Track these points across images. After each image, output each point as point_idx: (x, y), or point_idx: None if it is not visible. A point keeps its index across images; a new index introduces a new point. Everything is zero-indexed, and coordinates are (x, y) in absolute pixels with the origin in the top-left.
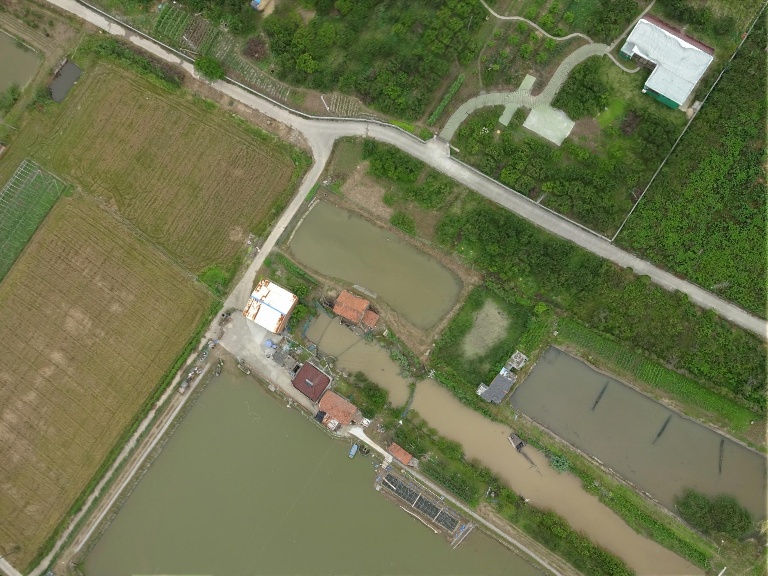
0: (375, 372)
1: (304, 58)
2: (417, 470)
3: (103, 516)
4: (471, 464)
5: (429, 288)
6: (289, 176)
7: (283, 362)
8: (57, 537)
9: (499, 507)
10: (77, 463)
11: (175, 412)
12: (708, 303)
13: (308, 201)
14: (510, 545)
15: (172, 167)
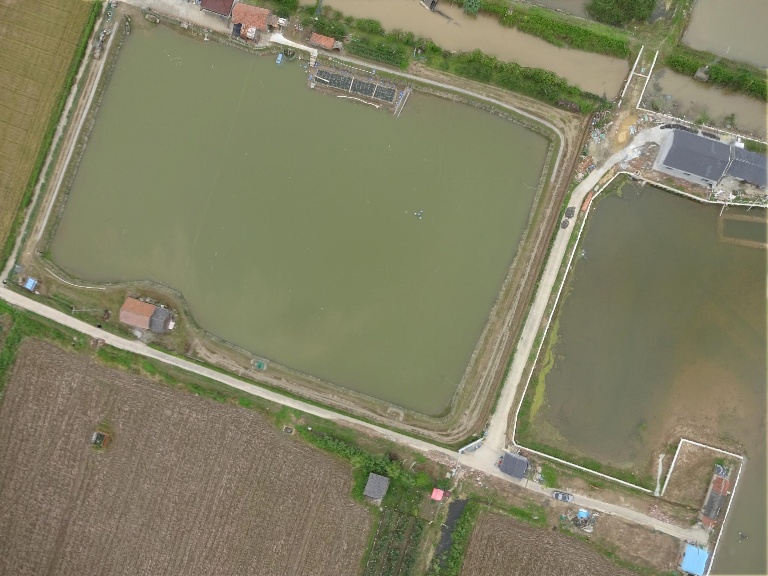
0: None
1: None
2: (343, 54)
3: (55, 198)
4: (392, 34)
5: None
6: None
7: None
8: (15, 234)
9: (428, 60)
10: (14, 159)
11: (97, 79)
12: None
13: None
14: (448, 93)
15: None
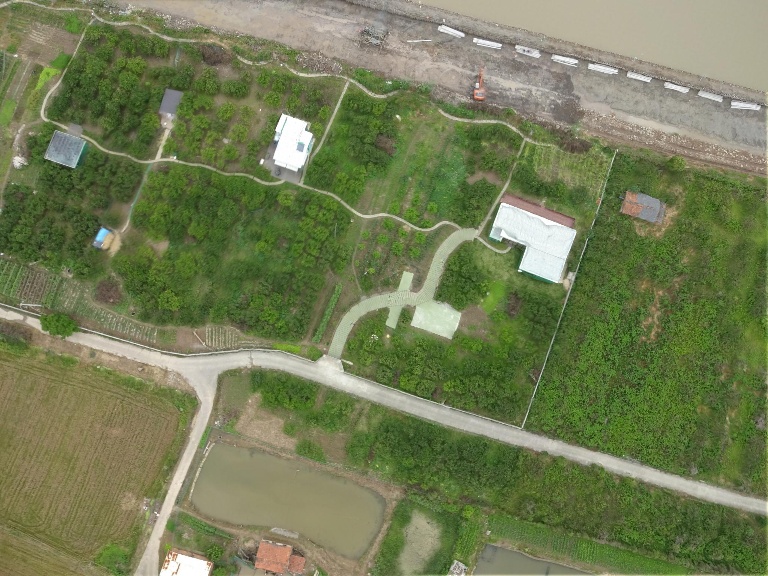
0: None
1: (166, 296)
2: None
3: None
4: None
5: (351, 513)
6: (175, 424)
7: None
8: None
9: None
10: None
11: None
12: (623, 470)
13: (202, 448)
14: None
15: (37, 441)
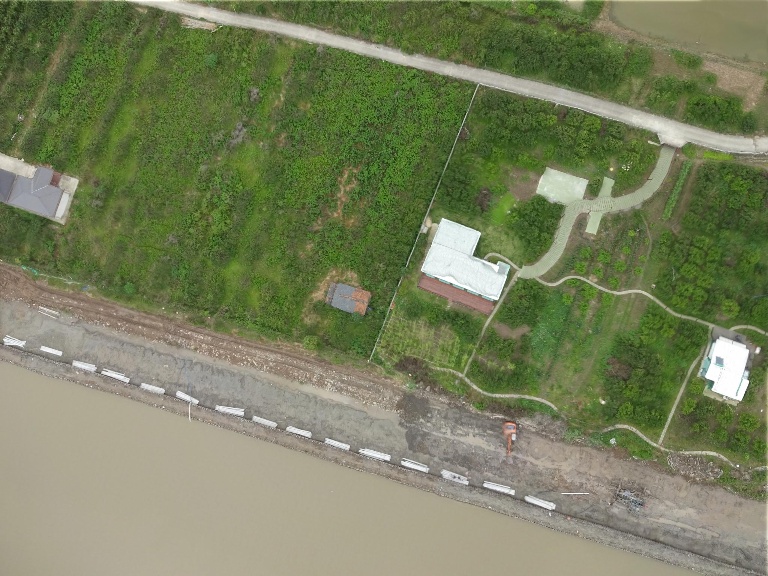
0: None
1: None
2: None
3: None
4: None
5: (643, 6)
6: None
7: None
8: None
9: None
10: None
11: None
12: (383, 51)
13: None
14: None
15: None
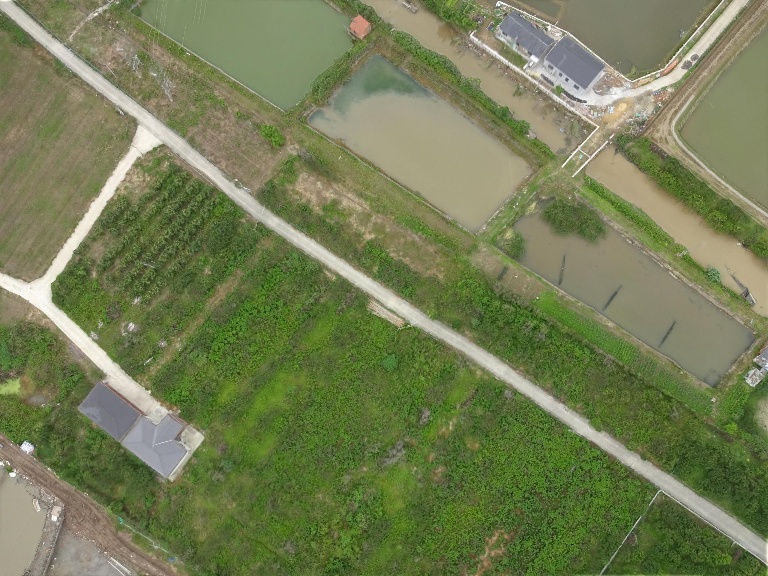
0: None
1: None
2: None
3: None
4: None
5: None
6: None
7: None
8: None
9: None
10: None
11: None
12: (570, 415)
13: None
14: (760, 206)
15: None
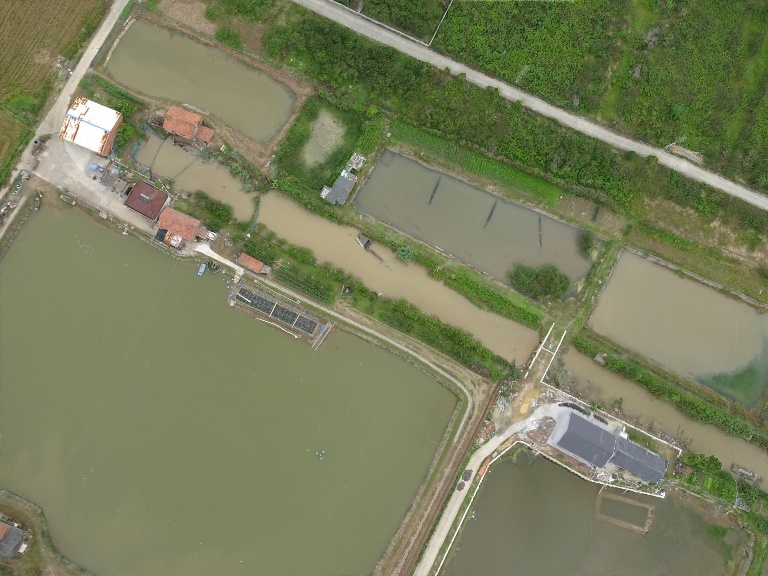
0: (216, 189)
1: None
2: (270, 278)
3: None
4: (323, 266)
5: (263, 102)
6: None
7: (113, 185)
8: None
9: (354, 301)
10: None
11: None
12: (515, 97)
13: (122, 19)
14: (369, 336)
15: None
